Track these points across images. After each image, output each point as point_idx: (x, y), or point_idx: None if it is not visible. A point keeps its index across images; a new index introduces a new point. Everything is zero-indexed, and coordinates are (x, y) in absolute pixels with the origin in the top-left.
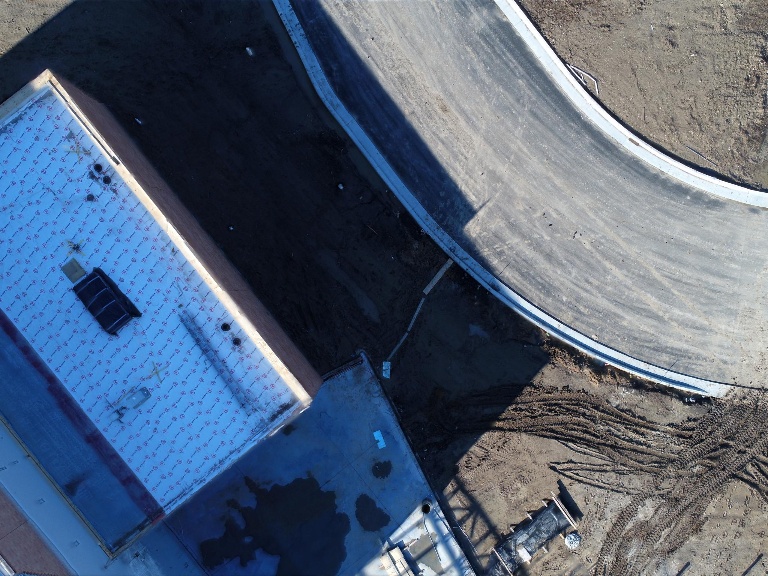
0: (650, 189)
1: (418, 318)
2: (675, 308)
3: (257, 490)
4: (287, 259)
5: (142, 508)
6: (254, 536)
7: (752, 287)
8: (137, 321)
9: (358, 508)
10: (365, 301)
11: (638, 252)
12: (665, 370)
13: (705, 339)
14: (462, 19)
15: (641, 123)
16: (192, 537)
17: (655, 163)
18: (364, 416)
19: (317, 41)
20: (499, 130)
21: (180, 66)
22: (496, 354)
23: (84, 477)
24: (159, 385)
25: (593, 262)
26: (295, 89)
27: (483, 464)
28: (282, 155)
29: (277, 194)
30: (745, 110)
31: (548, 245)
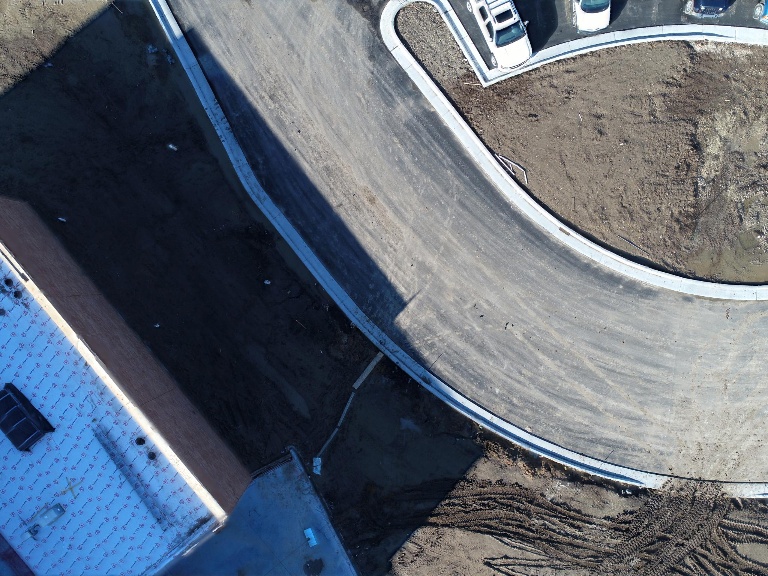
0: (582, 278)
1: (348, 413)
2: (609, 398)
3: None
4: (215, 355)
5: None
6: None
7: (687, 376)
8: (50, 436)
9: None
10: (294, 396)
11: (571, 342)
12: (600, 462)
13: (640, 429)
14: (389, 110)
15: (571, 212)
16: None
17: (586, 252)
18: (294, 514)
19: (243, 135)
20: (428, 221)
21: (105, 162)
22: (428, 448)
23: None
24: (73, 501)
25: (525, 353)
26: (221, 183)
27: (416, 560)
28: (209, 250)
29: (204, 290)
30: (676, 198)
31: (480, 336)
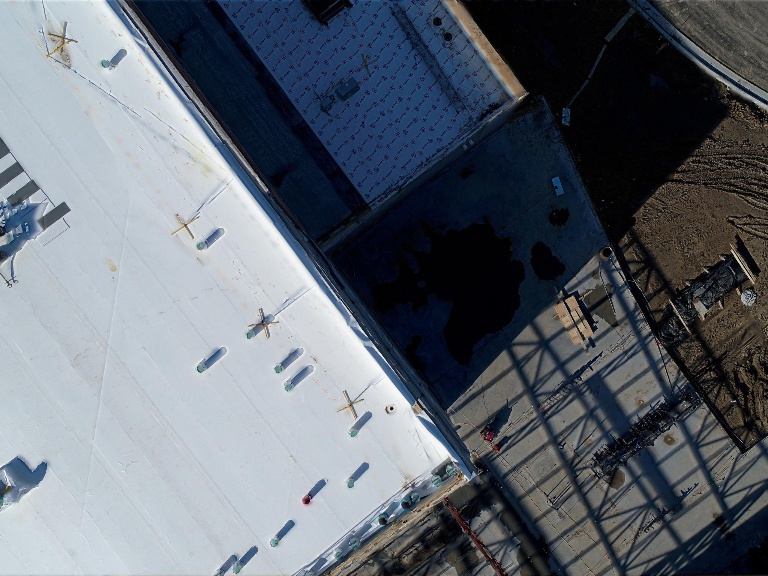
0: None
1: (599, 65)
2: None
3: (432, 234)
4: (469, 1)
5: (347, 203)
6: (427, 281)
7: None
8: (348, 12)
9: (533, 256)
10: (546, 47)
11: None
12: None
13: None
14: None
15: None
16: (364, 280)
17: None
18: (543, 162)
19: None
20: None
21: None
22: (676, 105)
23: (289, 169)
24: (368, 79)
25: None
26: None
27: (660, 217)
28: None
29: None
30: None
31: None
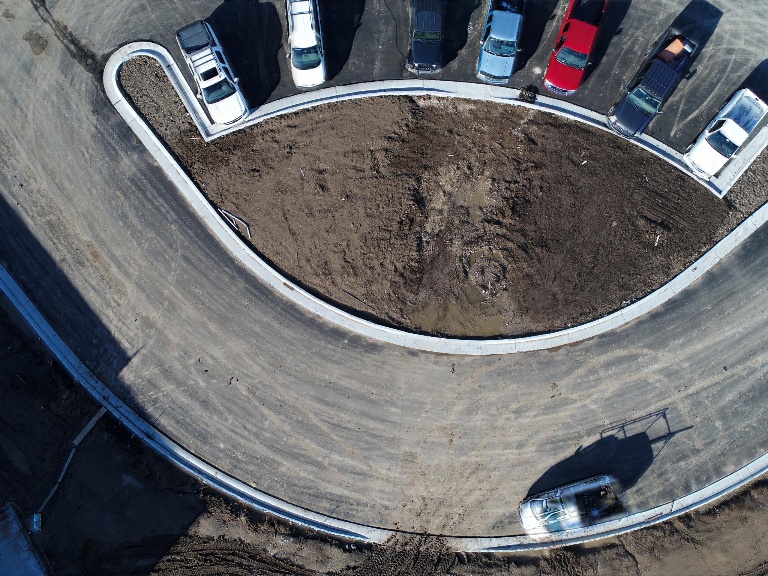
0: (307, 333)
1: (69, 469)
2: (335, 453)
3: None
4: None
5: None
6: None
7: (413, 431)
8: None
9: None
10: (15, 452)
11: (296, 397)
12: (325, 516)
13: (366, 484)
14: (113, 164)
15: (295, 267)
16: None
17: (310, 307)
18: (13, 570)
19: None
20: (152, 276)
21: None
22: (150, 504)
23: None
24: None
25: (250, 408)
26: None
27: None
28: None
29: None
30: (399, 253)
31: (204, 391)
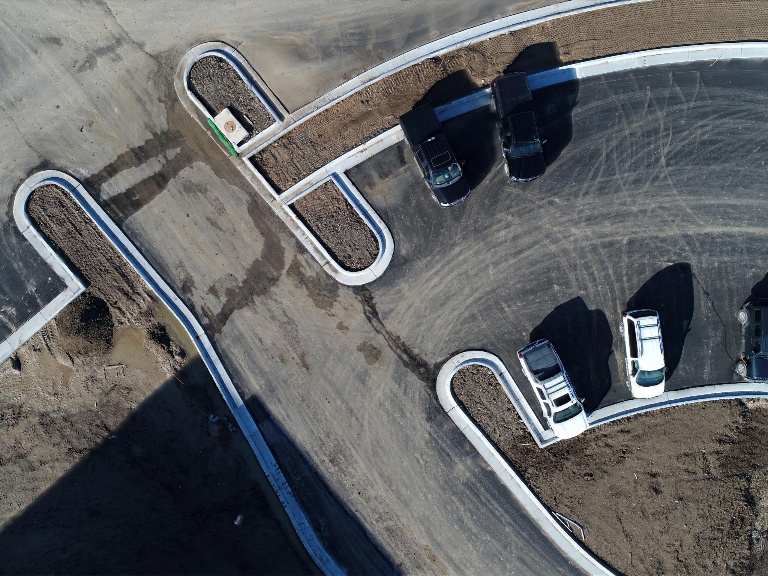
0: None
1: None
2: None
3: None
4: None
5: None
6: None
7: None
8: None
9: None
10: None
11: None
12: None
13: None
14: (447, 470)
15: (628, 567)
16: None
17: None
18: None
19: (304, 498)
20: None
21: (170, 532)
22: None
23: None
24: None
25: None
26: (284, 547)
27: None
28: None
29: None
30: (731, 552)
31: None
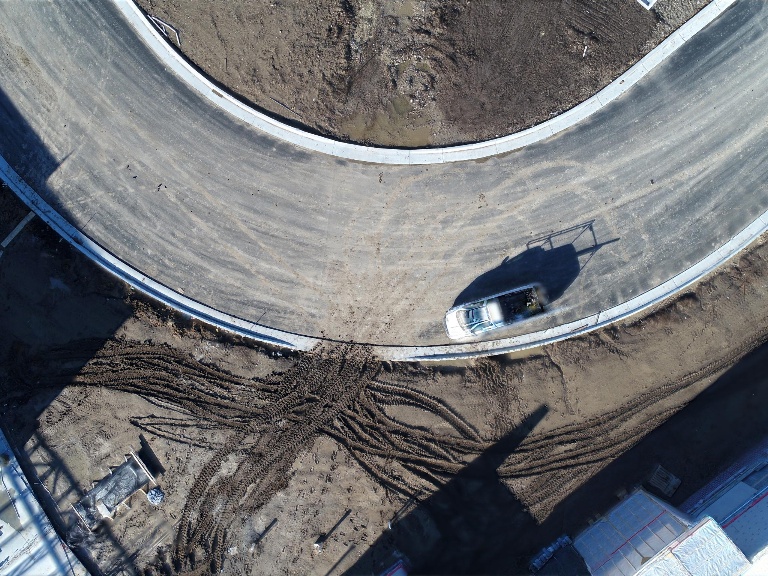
0: (235, 141)
1: None
2: (262, 261)
3: None
4: None
5: None
6: None
7: (340, 239)
8: None
9: None
10: None
11: (224, 204)
12: (251, 323)
13: (292, 292)
14: None
15: (224, 74)
16: None
17: (239, 114)
18: None
19: None
20: (82, 82)
21: None
22: (77, 307)
23: None
24: None
25: (178, 215)
26: None
27: (64, 419)
28: None
29: None
30: (327, 61)
31: (133, 198)
